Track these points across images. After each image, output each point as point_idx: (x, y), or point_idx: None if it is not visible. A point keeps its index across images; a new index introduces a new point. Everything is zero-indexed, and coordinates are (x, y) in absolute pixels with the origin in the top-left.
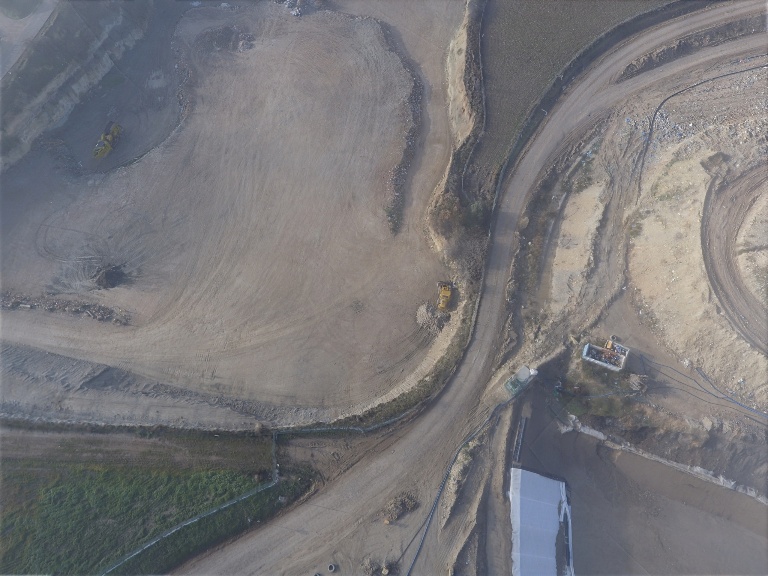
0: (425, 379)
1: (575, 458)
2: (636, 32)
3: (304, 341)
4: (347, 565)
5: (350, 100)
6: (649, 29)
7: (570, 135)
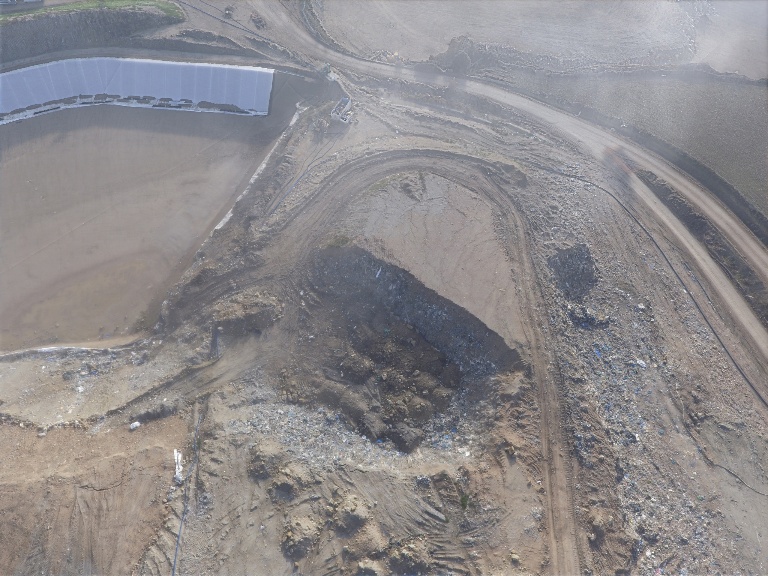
0: (335, 42)
1: (282, 121)
2: (709, 189)
3: (365, 3)
4: (233, 0)
5: (581, 27)
6: (717, 198)
7: (554, 127)
